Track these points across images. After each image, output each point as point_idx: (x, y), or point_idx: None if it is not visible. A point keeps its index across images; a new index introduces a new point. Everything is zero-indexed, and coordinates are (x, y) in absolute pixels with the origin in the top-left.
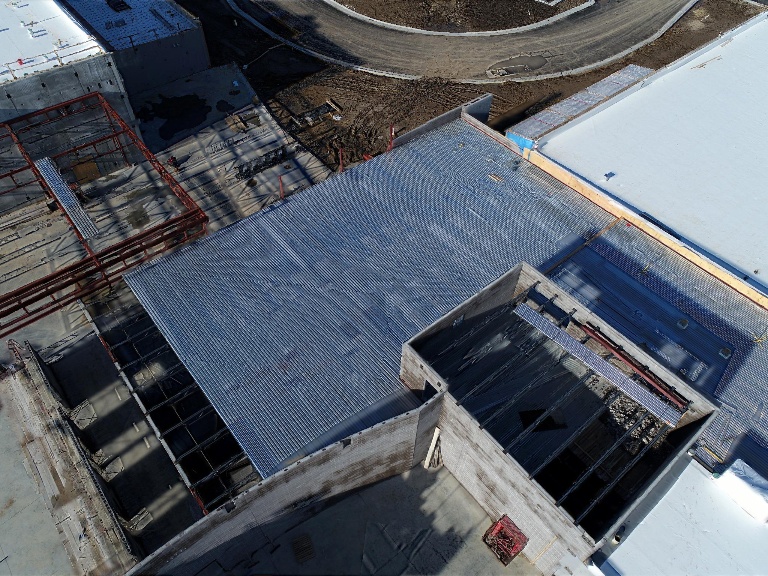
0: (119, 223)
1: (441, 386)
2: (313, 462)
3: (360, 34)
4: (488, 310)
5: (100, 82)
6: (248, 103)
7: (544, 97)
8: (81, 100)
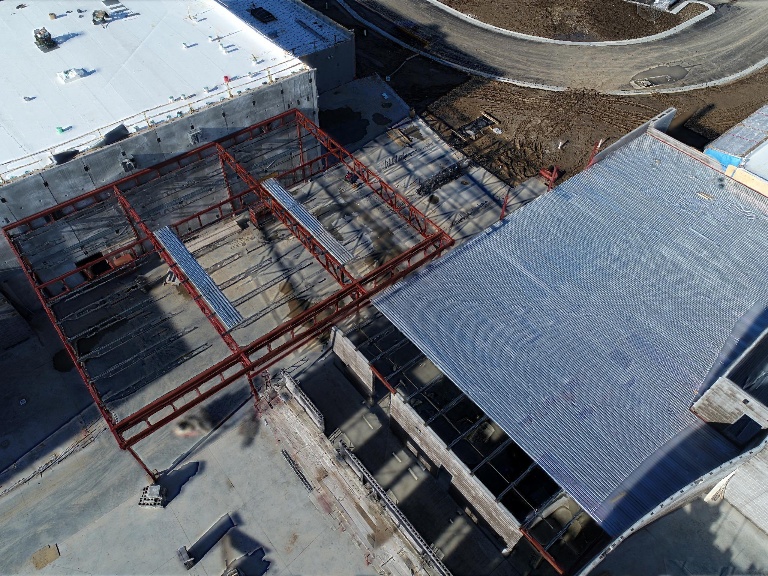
0: None
1: None
2: None
3: (491, 44)
4: None
5: (299, 99)
6: (404, 116)
7: (698, 109)
8: (281, 117)
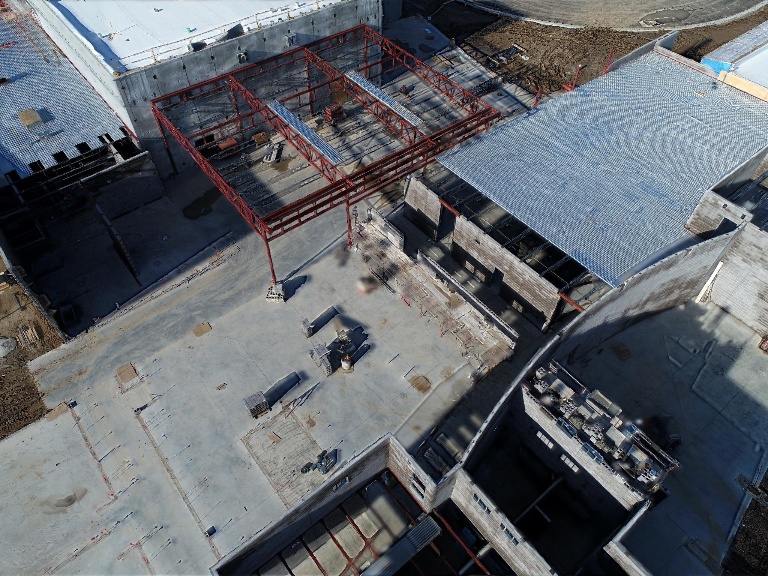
0: (378, 135)
1: (745, 218)
2: (666, 265)
3: None
4: (741, 181)
5: (369, 16)
6: (445, 46)
7: (698, 42)
8: (354, 30)
